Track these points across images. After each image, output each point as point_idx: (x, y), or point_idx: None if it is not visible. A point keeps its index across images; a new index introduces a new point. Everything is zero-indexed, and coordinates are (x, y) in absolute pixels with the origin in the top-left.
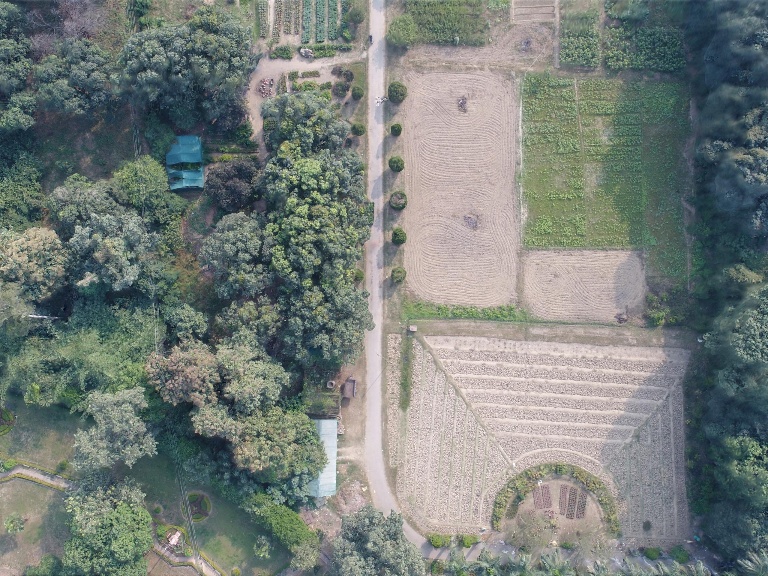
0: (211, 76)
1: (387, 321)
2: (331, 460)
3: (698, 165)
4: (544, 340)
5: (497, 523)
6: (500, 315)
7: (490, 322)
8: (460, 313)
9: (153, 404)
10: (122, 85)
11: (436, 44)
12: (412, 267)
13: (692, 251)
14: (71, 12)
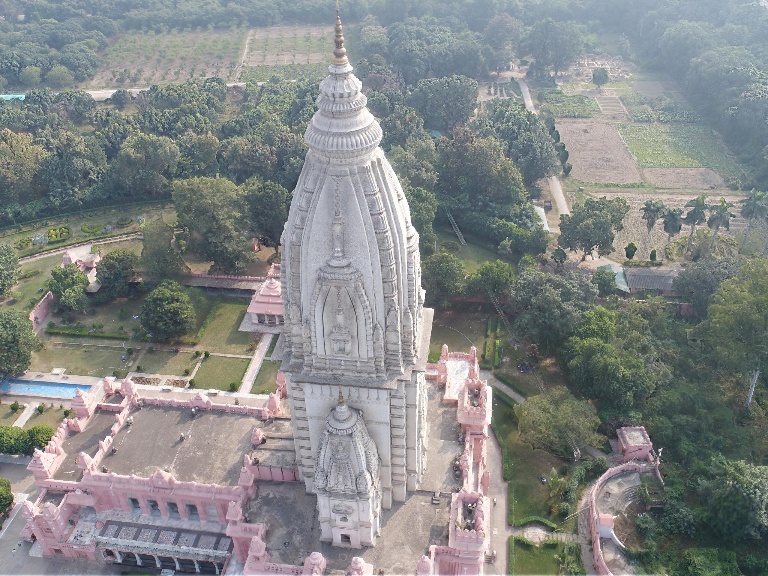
0: (461, 88)
1: (564, 187)
2: (544, 221)
3: (728, 146)
4: (668, 194)
5: (671, 256)
6: (635, 185)
7: (630, 188)
8: (610, 184)
9: (436, 164)
10: (413, 95)
11: (565, 117)
12: (574, 172)
13: (743, 167)
14: (387, 83)
